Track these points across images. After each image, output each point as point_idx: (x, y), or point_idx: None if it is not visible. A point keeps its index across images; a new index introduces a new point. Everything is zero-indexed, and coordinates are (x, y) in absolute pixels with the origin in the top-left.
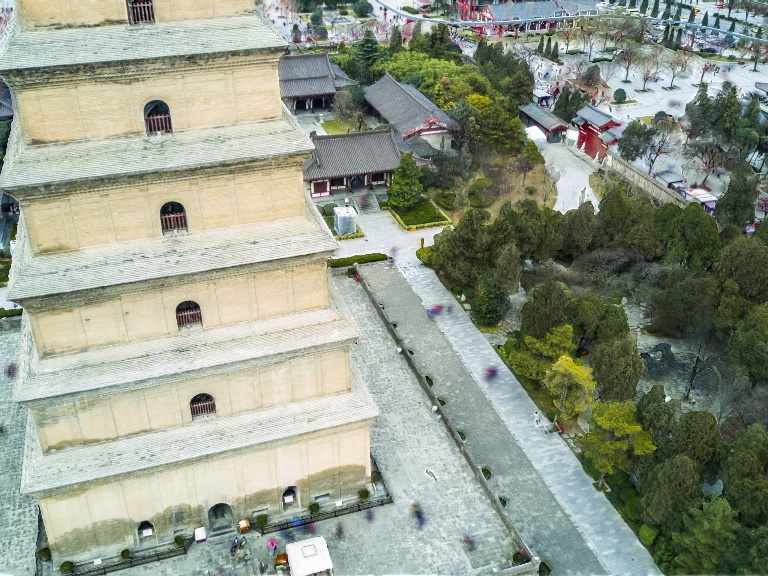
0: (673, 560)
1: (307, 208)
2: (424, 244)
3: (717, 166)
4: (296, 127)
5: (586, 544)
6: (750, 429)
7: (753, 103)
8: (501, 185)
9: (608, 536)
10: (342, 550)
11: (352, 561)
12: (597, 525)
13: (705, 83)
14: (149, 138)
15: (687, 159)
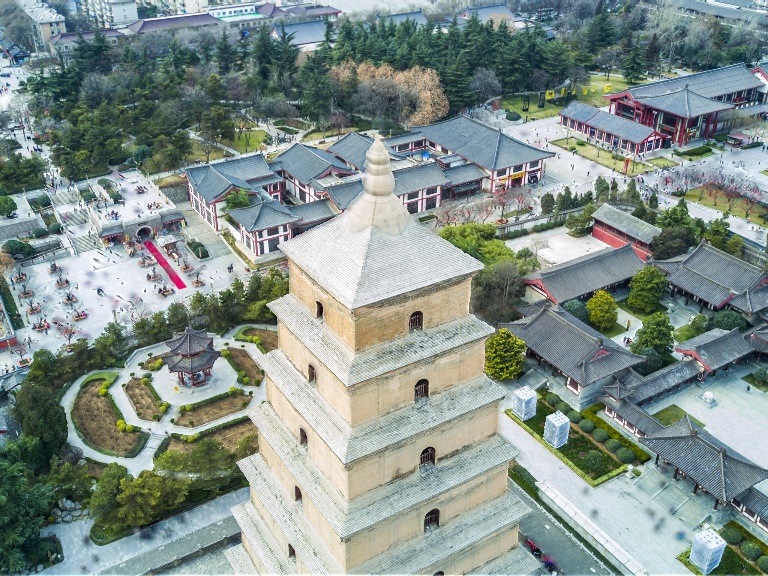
0: None
1: (378, 569)
2: None
3: None
4: (359, 514)
5: None
6: None
7: None
8: None
9: None
10: None
11: None
12: None
13: None
14: (299, 446)
15: None
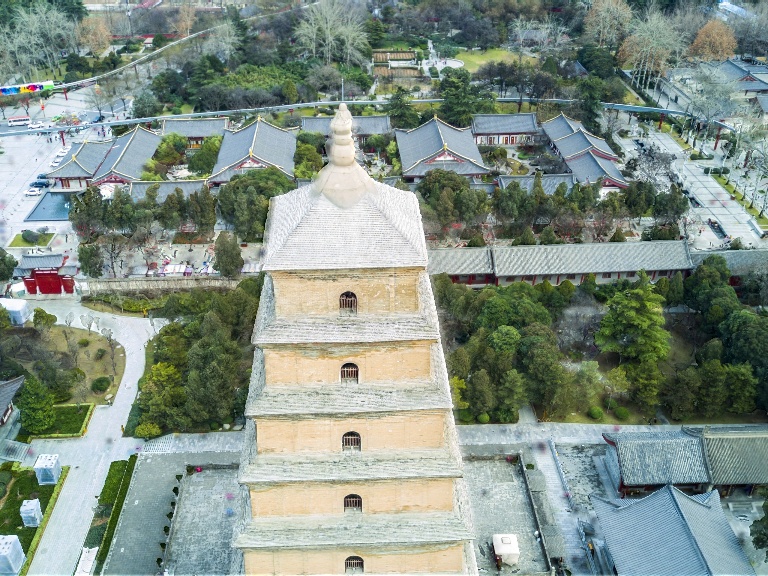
0: (509, 413)
1: None
2: (115, 431)
3: (159, 245)
4: None
5: (480, 445)
6: (472, 341)
7: (118, 192)
8: (86, 352)
9: (477, 435)
10: (491, 536)
11: (500, 533)
12: (468, 436)
13: (74, 194)
14: None
15: (136, 252)
